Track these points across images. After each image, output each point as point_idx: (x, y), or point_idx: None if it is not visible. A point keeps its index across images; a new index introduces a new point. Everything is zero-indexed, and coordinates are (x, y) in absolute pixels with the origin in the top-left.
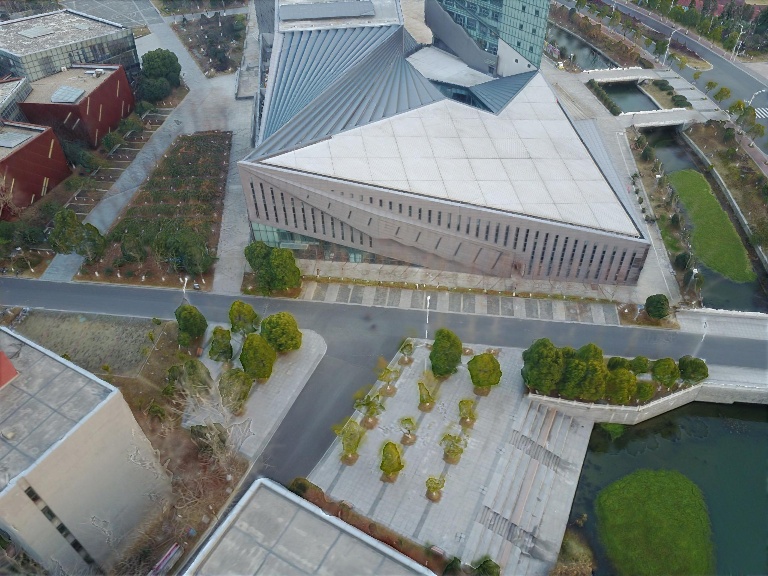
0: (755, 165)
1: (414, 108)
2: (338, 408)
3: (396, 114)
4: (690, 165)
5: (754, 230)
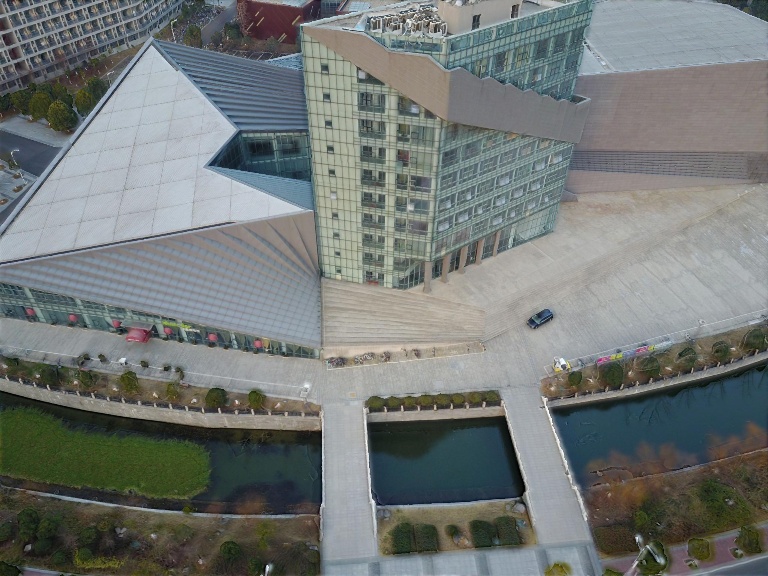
0: (146, 575)
1: (220, 110)
2: (3, 150)
3: (210, 100)
4: (221, 495)
5: (6, 490)
